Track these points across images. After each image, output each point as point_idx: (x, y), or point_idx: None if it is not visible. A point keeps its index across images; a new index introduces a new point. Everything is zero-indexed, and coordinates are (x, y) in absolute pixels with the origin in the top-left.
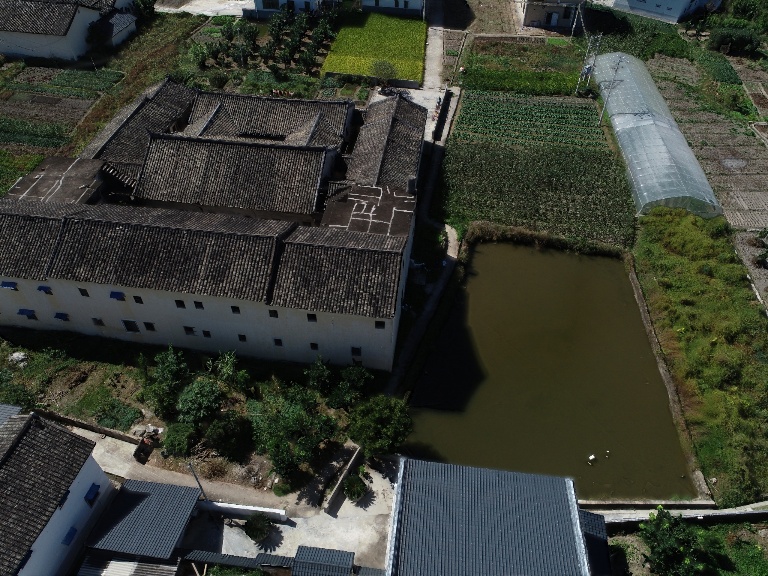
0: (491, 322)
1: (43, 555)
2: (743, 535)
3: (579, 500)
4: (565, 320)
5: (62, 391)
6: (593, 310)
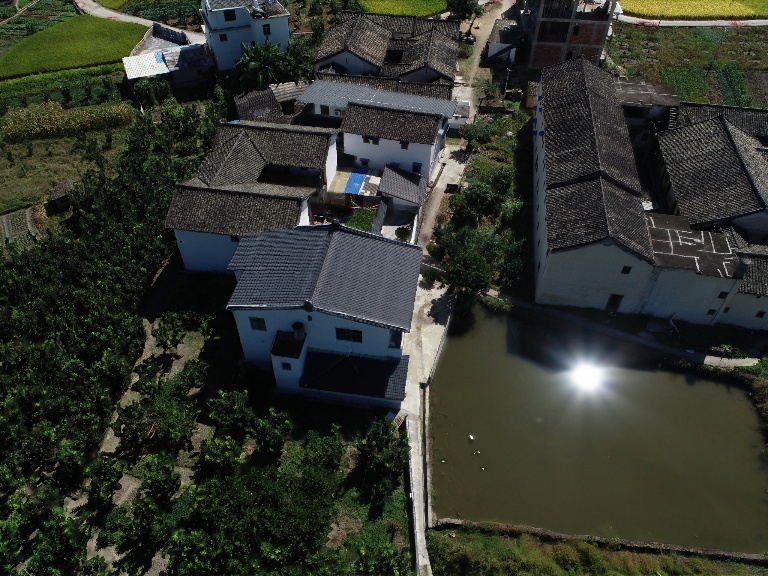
0: (620, 386)
1: (383, 154)
2: (399, 541)
3: (428, 412)
4: (646, 459)
5: (489, 155)
6: (673, 493)
